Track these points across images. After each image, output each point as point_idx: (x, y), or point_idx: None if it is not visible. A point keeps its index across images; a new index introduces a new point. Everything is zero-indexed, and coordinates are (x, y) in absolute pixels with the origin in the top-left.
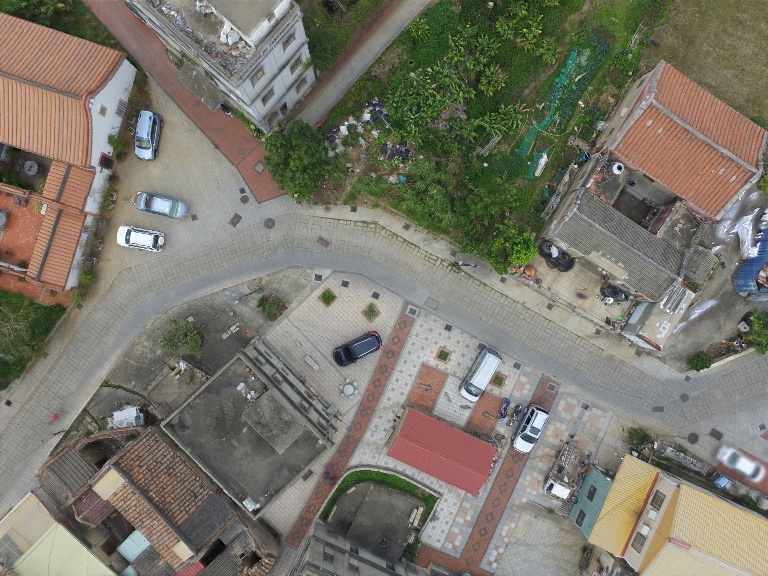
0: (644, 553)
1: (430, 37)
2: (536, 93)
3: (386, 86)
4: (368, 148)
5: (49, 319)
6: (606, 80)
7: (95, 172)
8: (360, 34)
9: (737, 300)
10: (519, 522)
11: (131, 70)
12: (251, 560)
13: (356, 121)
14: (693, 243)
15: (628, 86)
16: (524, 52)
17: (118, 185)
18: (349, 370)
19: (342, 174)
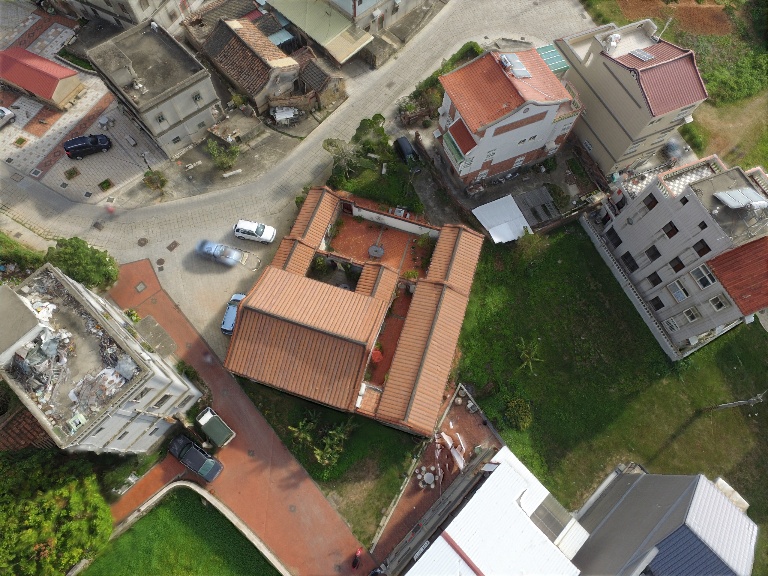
0: None
1: None
2: None
3: None
4: None
5: None
6: None
7: None
8: None
9: None
10: (1, 39)
11: None
12: None
13: None
14: None
15: None
16: None
17: None
18: None
19: None
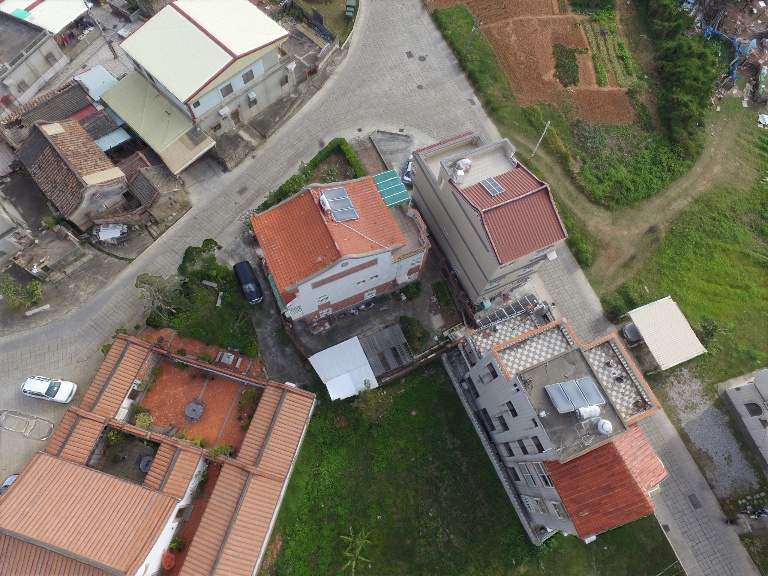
0: None
1: None
2: None
3: None
4: None
5: None
6: None
7: None
8: None
9: None
10: None
11: None
12: (17, 124)
13: None
14: None
15: None
16: None
17: None
18: None
19: None
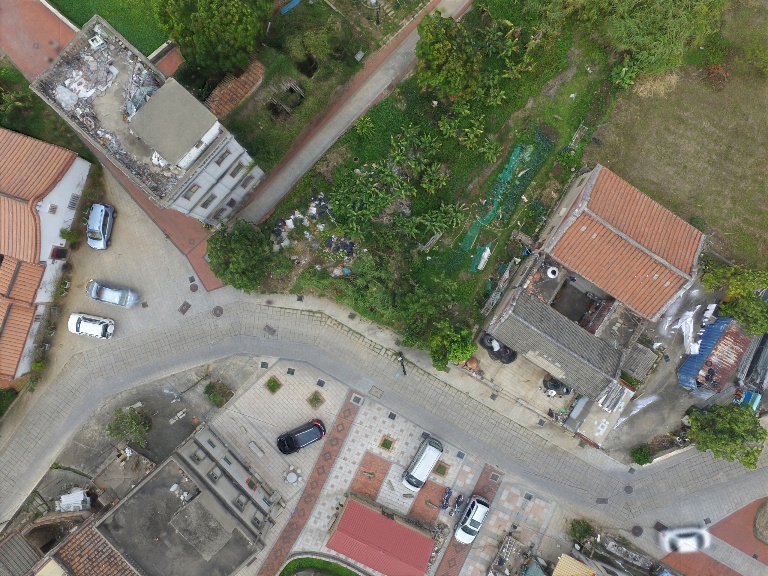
0: None
1: (375, 134)
2: (479, 188)
3: (331, 182)
4: (313, 241)
5: (0, 404)
6: (549, 176)
7: (45, 266)
8: (308, 129)
9: (681, 393)
10: None
11: (84, 165)
12: None
13: (302, 215)
14: (630, 343)
15: (571, 181)
16: (467, 150)
17: (72, 272)
18: (293, 457)
19: (285, 269)
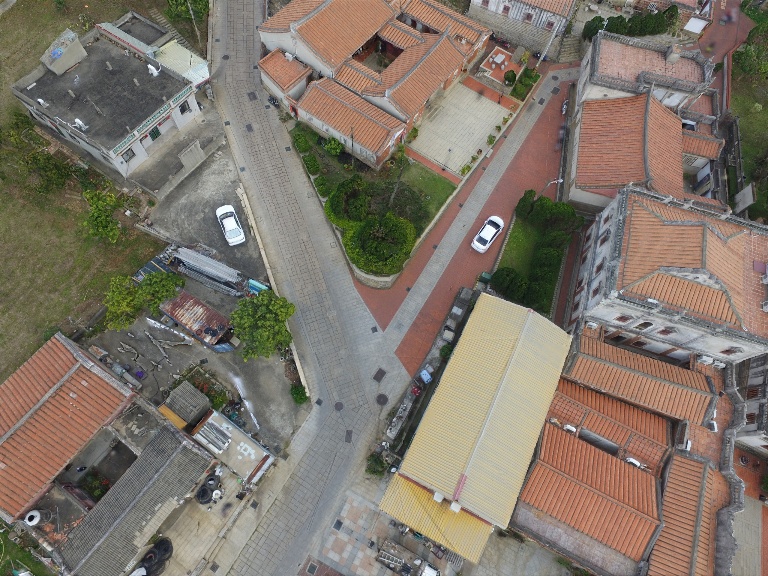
0: None
1: None
2: None
3: None
4: None
5: None
6: None
7: None
8: None
9: None
10: None
11: None
12: None
13: None
14: None
15: None
16: None
17: None
18: None
19: None
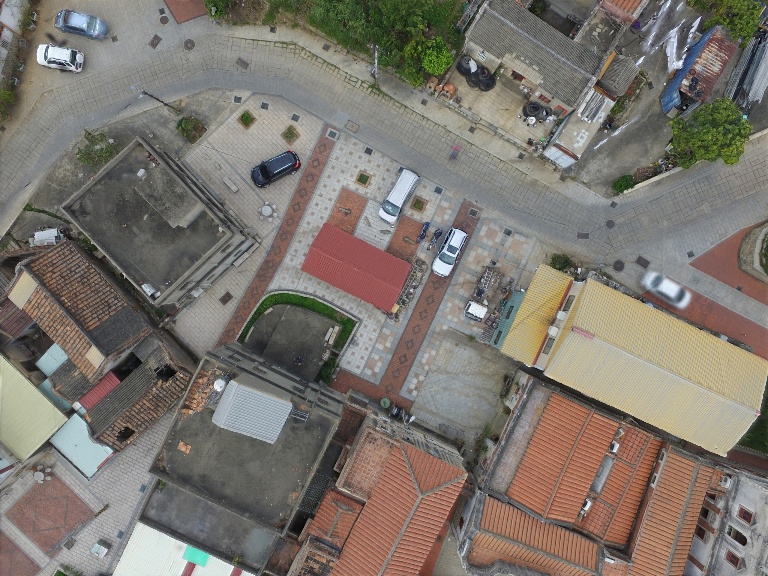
0: (551, 351)
1: None
2: None
3: None
4: None
5: None
6: None
7: None
8: None
9: (665, 122)
10: (440, 350)
11: None
12: (166, 375)
13: None
14: (611, 46)
15: None
16: None
17: (39, 6)
18: (269, 194)
19: None
